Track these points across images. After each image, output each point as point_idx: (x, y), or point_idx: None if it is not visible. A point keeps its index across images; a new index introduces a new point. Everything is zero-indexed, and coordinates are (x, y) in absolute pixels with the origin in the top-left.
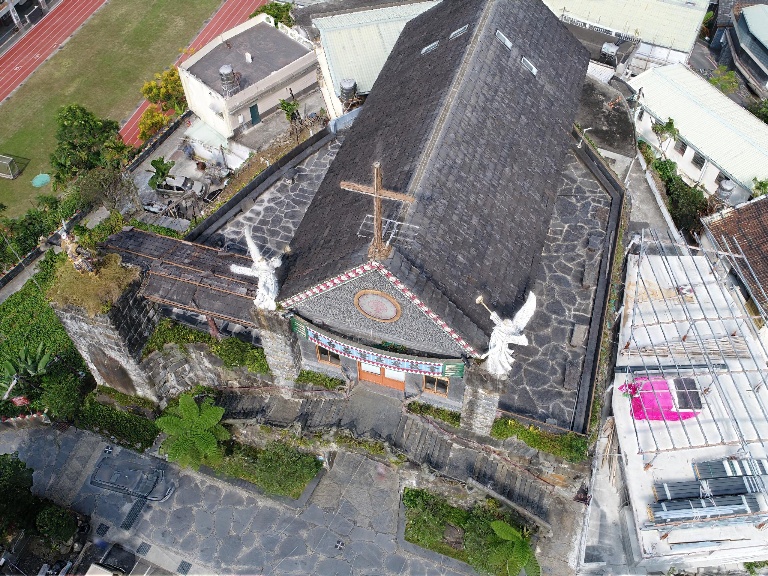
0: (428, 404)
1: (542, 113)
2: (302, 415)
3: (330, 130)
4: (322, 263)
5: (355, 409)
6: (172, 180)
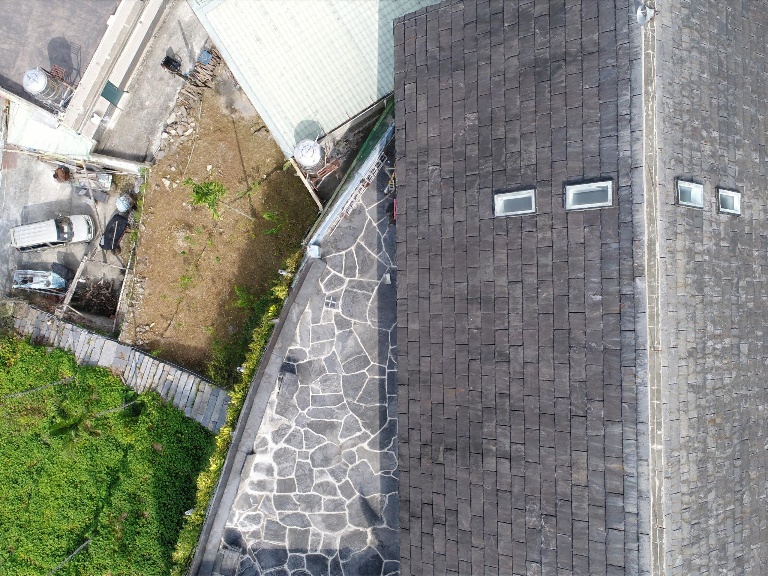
0: None
1: (759, 291)
2: None
3: (312, 258)
4: None
5: None
6: (37, 235)
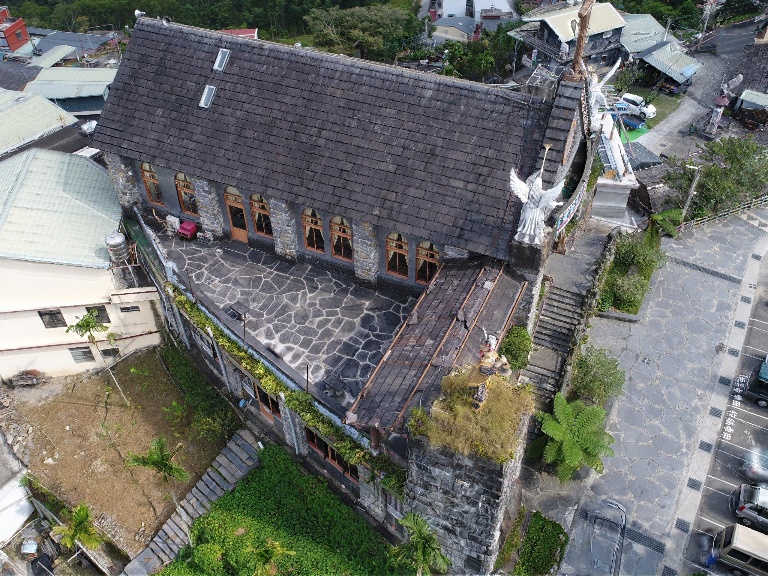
0: (560, 234)
1: None
2: (552, 341)
3: None
4: None
5: (563, 283)
6: None
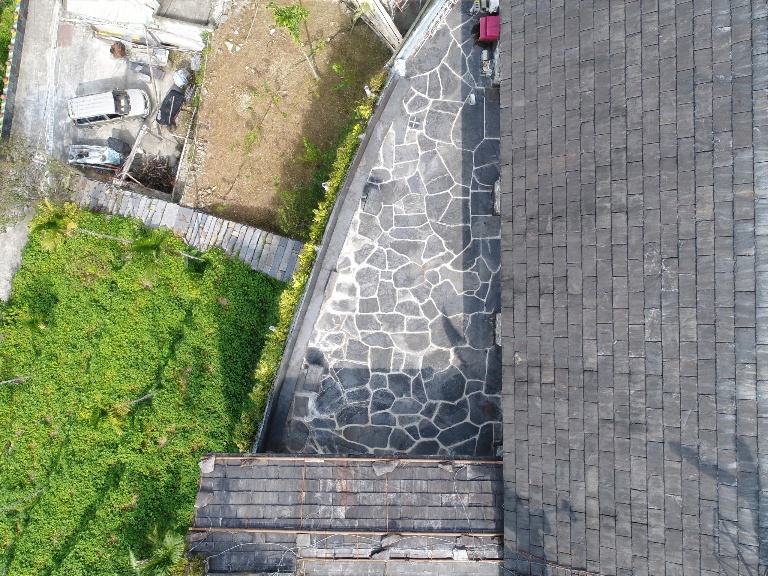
0: None
1: None
2: None
3: (398, 76)
4: (624, 570)
5: None
6: (95, 106)
